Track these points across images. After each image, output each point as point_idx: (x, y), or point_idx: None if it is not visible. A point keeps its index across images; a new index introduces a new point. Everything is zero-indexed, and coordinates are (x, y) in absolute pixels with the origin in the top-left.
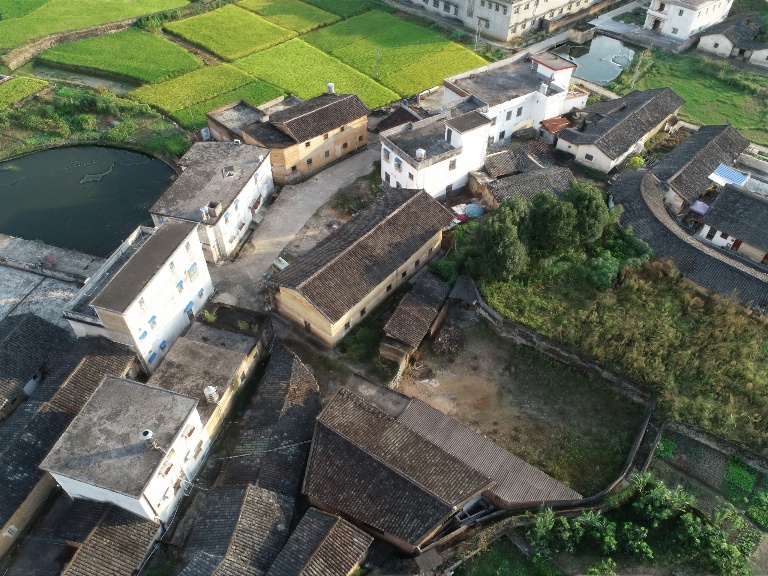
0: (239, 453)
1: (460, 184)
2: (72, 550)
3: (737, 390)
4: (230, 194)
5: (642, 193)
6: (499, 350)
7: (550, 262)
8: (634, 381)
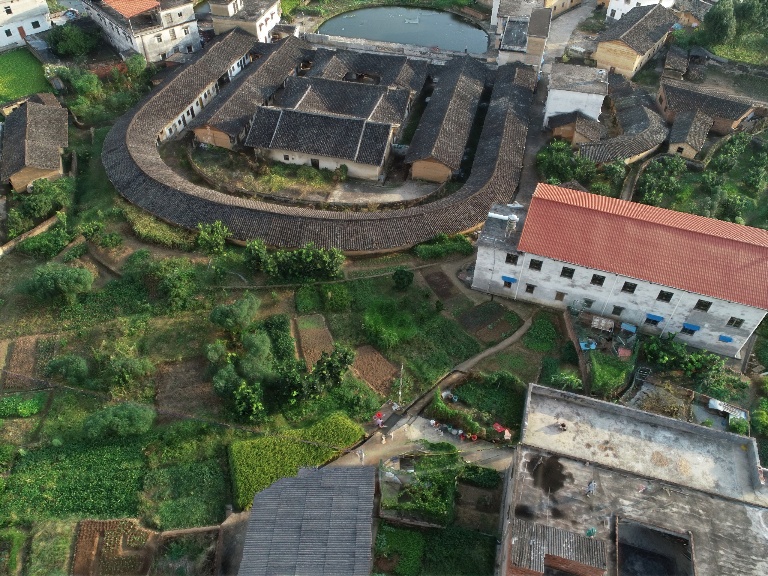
0: (619, 105)
1: None
2: (557, 136)
3: None
4: None
5: None
6: (726, 78)
7: (744, 37)
8: None
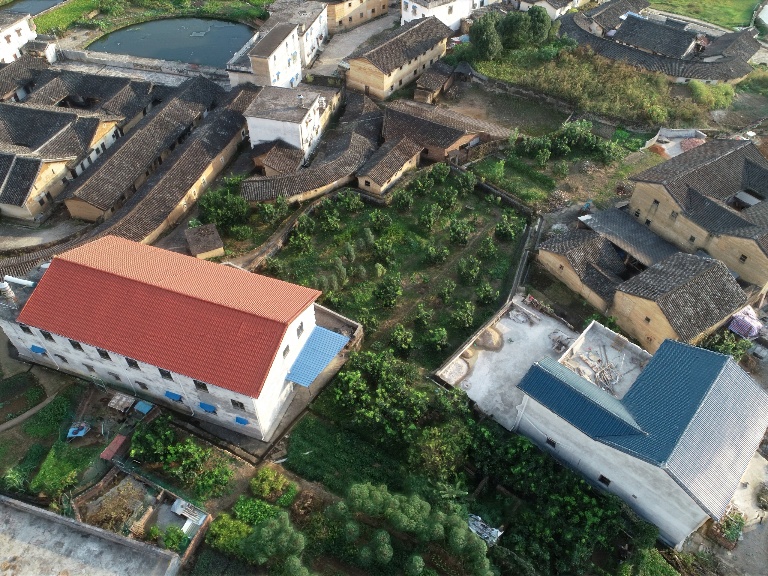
0: (341, 130)
1: (455, 27)
2: (258, 167)
3: (623, 98)
4: (308, 23)
5: (574, 20)
6: (486, 97)
7: (516, 52)
8: (565, 99)
